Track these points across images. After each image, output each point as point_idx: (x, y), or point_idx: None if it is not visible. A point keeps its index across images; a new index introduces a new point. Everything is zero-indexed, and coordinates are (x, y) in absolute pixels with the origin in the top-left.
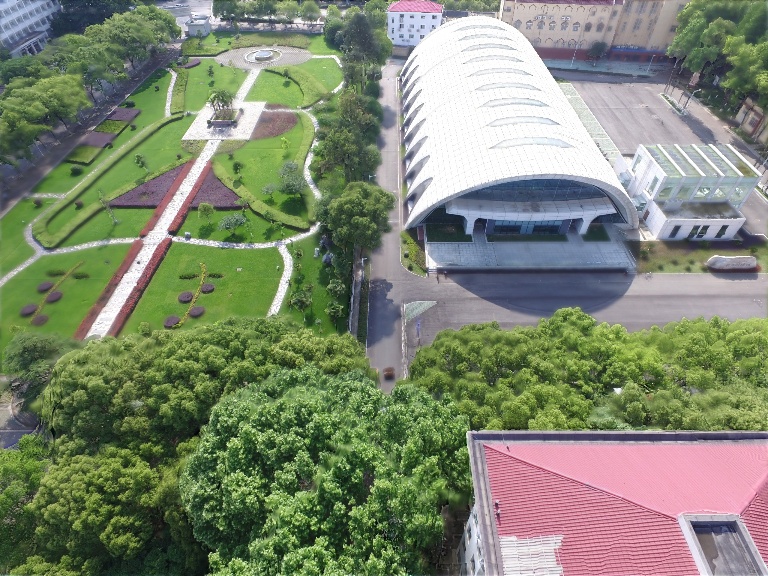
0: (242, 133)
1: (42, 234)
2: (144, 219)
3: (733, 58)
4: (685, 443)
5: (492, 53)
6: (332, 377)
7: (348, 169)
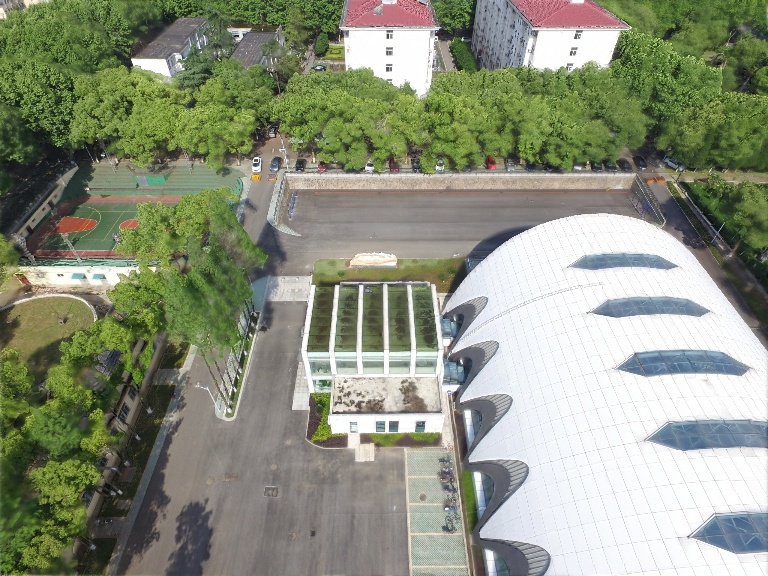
0: None
1: None
2: None
3: None
4: (567, 26)
5: None
6: (683, 110)
7: None
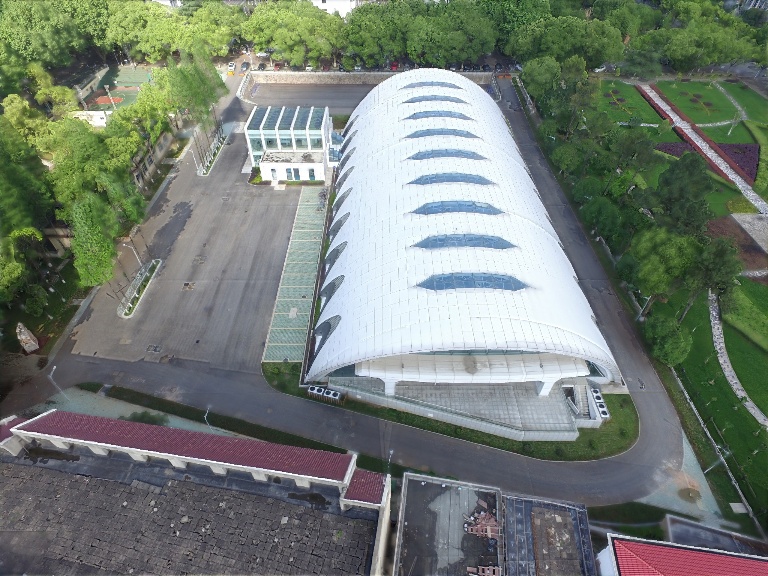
0: (751, 222)
1: (765, 126)
2: (711, 137)
3: None
4: None
5: (457, 187)
6: None
7: (579, 154)
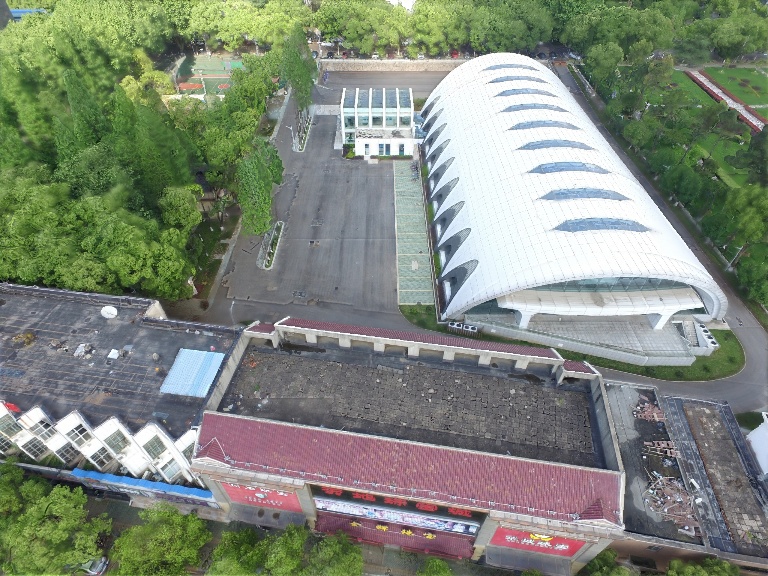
0: None
1: None
2: (765, 117)
3: (249, 147)
4: None
5: (565, 151)
6: None
7: None
